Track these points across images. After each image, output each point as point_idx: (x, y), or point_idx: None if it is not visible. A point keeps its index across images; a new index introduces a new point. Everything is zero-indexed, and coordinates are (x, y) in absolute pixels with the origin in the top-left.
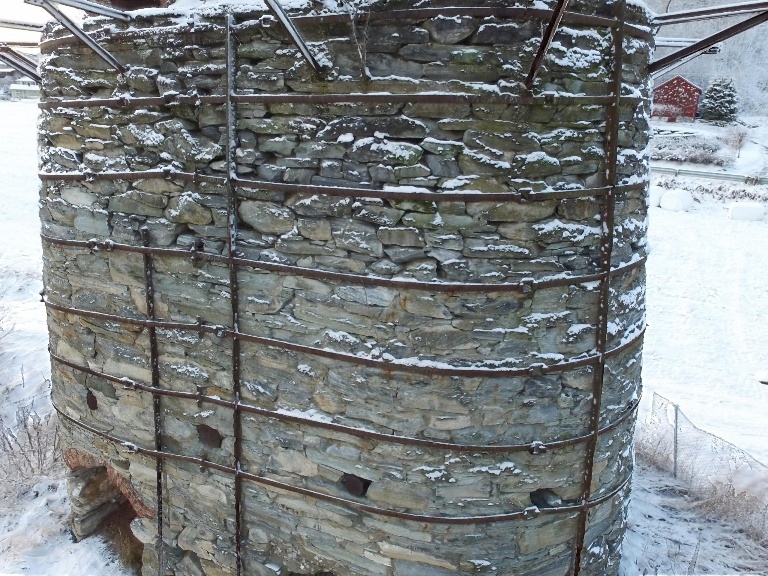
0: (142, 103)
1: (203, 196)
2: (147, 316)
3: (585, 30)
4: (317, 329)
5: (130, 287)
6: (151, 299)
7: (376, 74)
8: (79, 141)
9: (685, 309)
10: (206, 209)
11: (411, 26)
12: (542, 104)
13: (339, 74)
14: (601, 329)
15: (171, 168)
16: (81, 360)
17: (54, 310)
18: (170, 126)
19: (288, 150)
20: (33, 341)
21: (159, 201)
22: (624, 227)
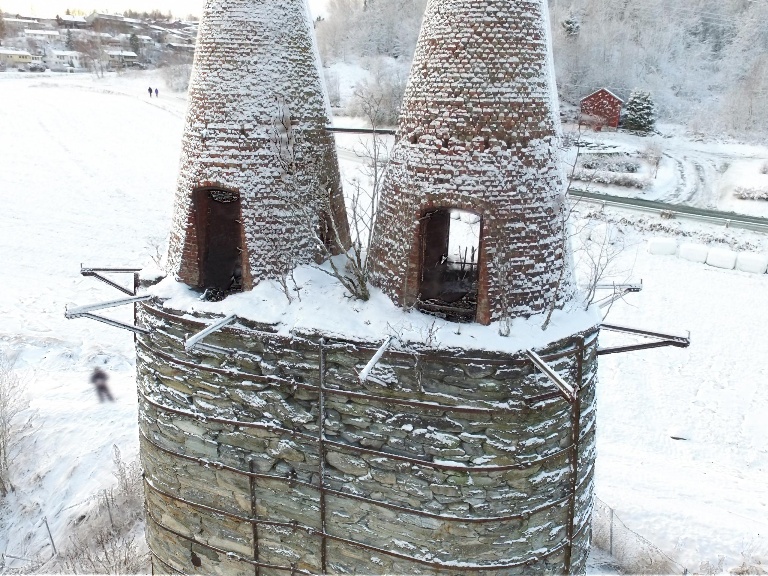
0: (248, 377)
1: (298, 444)
2: (248, 512)
3: (560, 359)
4: (386, 537)
5: (235, 493)
6: (254, 504)
7: (428, 390)
8: (190, 390)
9: (614, 363)
10: (300, 453)
11: (452, 366)
12: (535, 413)
13: (402, 387)
14: (570, 526)
15: (273, 425)
16: (187, 533)
17: (161, 495)
18: (271, 396)
19: (364, 426)
20: (49, 422)
21: (262, 443)
22: (583, 458)
